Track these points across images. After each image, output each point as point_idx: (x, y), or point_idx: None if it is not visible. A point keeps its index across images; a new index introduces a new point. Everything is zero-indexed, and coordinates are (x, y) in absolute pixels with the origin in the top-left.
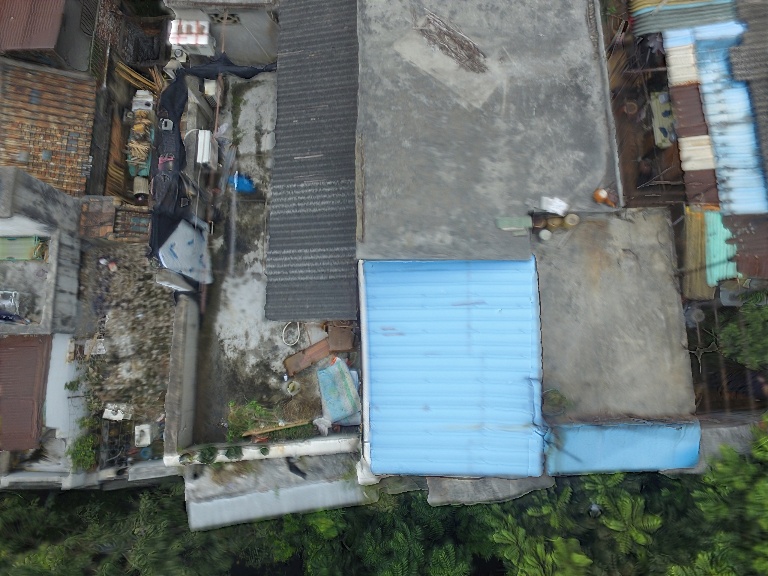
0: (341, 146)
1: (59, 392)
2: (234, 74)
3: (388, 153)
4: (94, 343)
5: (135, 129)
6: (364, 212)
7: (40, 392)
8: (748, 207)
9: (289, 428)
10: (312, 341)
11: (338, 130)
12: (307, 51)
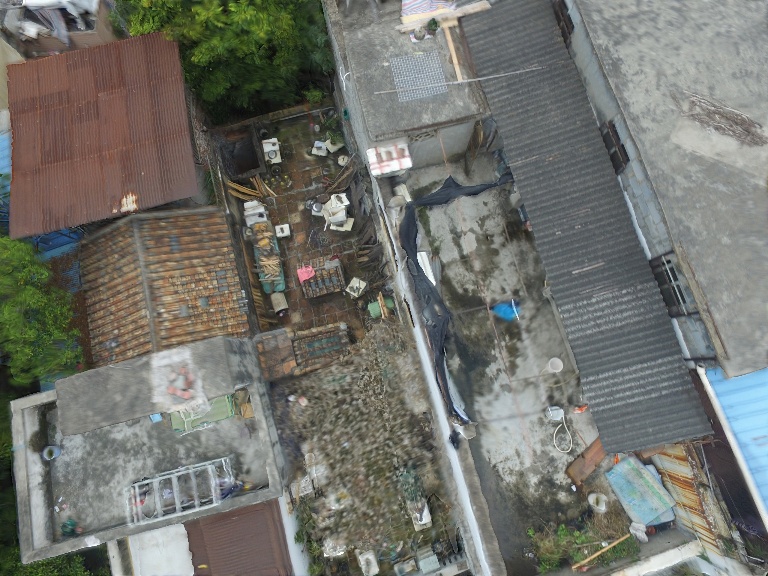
0: (621, 249)
1: (294, 549)
2: (465, 195)
3: (713, 255)
4: (299, 483)
5: (261, 246)
6: (716, 326)
7: (284, 558)
8: None
9: (614, 546)
10: (587, 442)
11: (611, 233)
12: (542, 156)
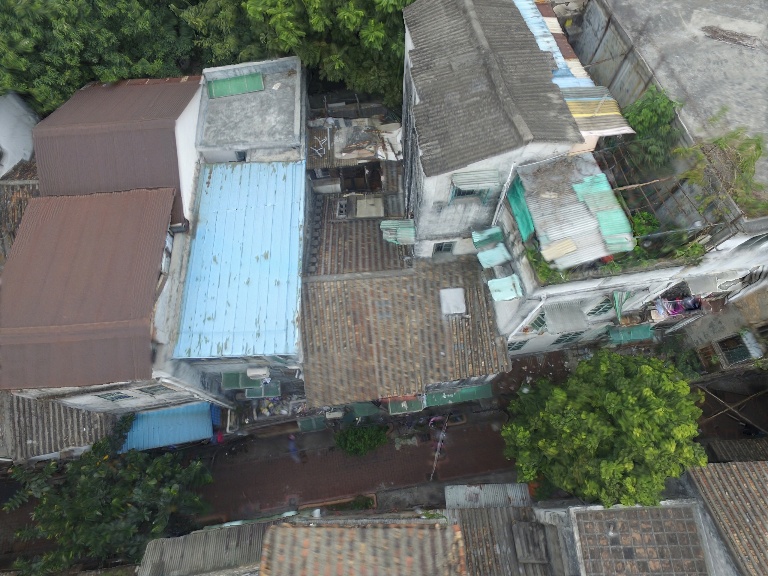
0: None
1: None
2: None
3: None
4: None
5: None
6: None
7: None
8: (521, 3)
9: None
10: None
11: None
12: None
